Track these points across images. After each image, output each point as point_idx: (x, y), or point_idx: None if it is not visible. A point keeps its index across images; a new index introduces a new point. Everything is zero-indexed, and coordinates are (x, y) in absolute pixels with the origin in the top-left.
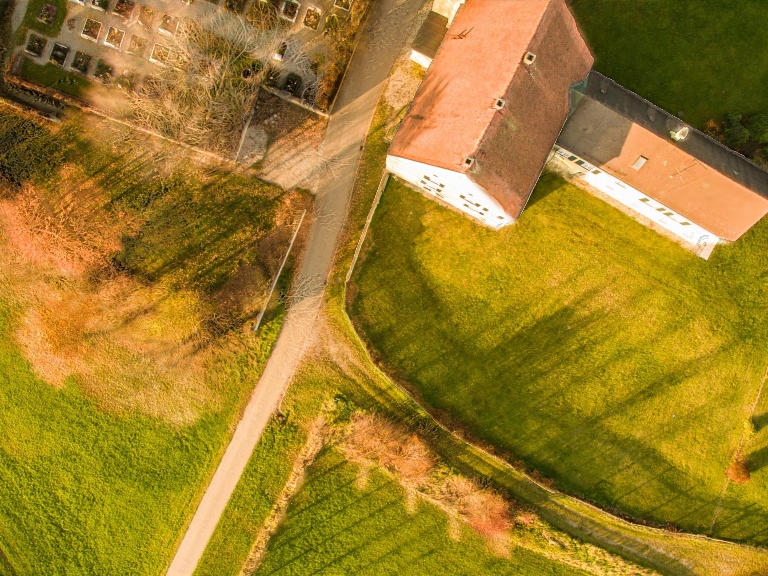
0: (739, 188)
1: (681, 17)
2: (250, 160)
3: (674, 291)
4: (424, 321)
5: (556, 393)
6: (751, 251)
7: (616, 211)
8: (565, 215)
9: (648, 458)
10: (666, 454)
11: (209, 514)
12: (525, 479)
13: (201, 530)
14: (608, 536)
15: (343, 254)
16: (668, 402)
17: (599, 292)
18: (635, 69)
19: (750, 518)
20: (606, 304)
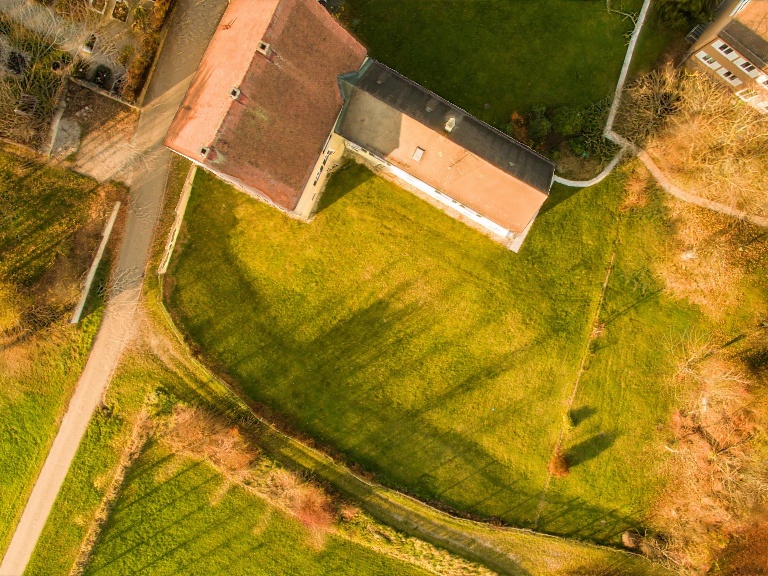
0: (511, 179)
1: (486, 9)
2: (64, 152)
3: (485, 284)
4: (242, 314)
5: (375, 386)
6: (561, 244)
7: (425, 204)
8: (374, 208)
9: (470, 452)
10: (488, 448)
11: (40, 507)
12: (348, 472)
13: (32, 523)
14: (434, 530)
15: (159, 247)
16: (487, 396)
17: (412, 285)
18: (440, 61)
19: (574, 512)
20: (419, 297)
